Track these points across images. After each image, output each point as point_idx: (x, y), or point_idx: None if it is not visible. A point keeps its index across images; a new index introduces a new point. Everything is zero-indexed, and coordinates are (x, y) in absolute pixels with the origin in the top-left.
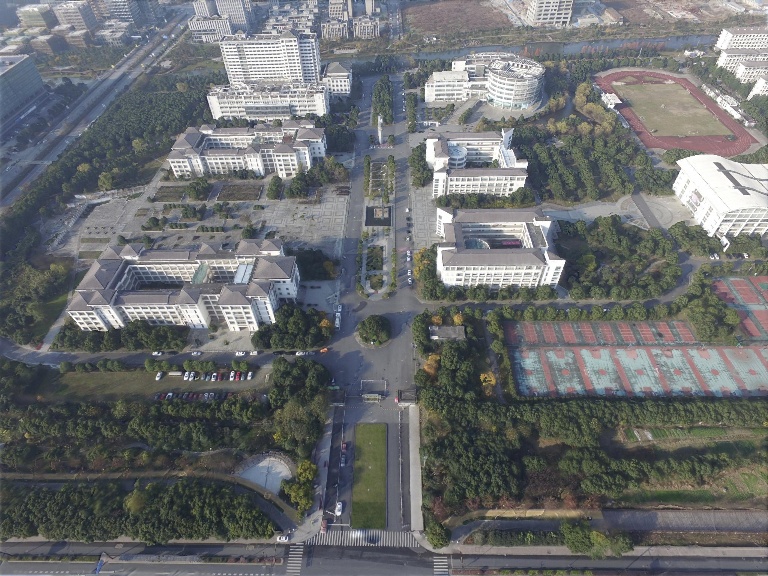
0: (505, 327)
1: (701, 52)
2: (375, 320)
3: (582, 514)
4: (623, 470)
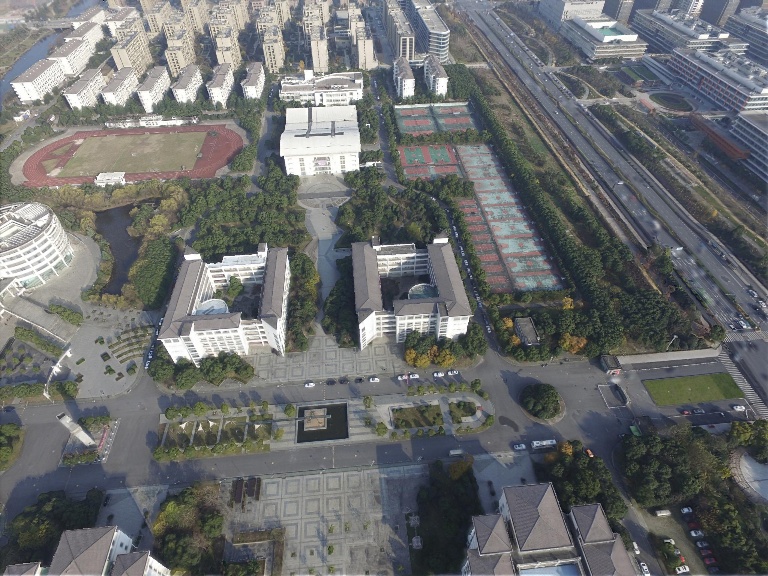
0: None
1: (27, 111)
2: (548, 389)
3: (653, 260)
4: (607, 241)
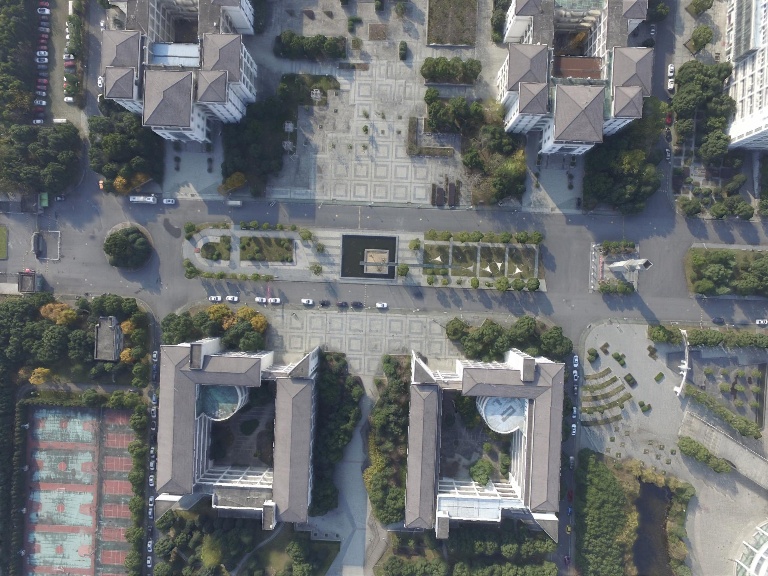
0: (129, 412)
1: None
2: (111, 247)
3: None
4: None
